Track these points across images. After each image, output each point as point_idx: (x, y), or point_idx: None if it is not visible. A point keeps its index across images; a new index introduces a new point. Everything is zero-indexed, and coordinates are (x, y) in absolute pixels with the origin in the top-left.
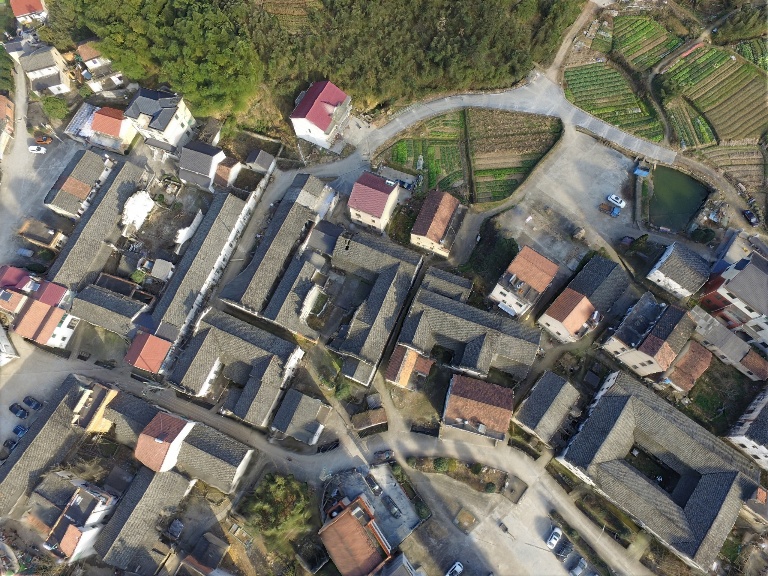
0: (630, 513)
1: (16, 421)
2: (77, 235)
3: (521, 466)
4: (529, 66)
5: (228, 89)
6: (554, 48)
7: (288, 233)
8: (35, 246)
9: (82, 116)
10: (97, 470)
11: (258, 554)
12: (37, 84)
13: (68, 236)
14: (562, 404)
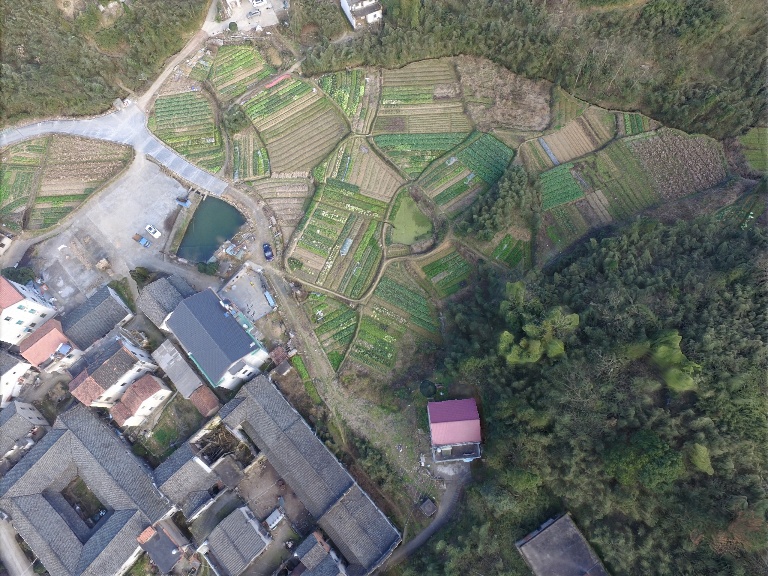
0: None
1: None
2: None
3: None
4: (106, 94)
5: None
6: (151, 76)
7: None
8: None
9: None
10: None
11: None
12: None
13: None
14: (7, 436)
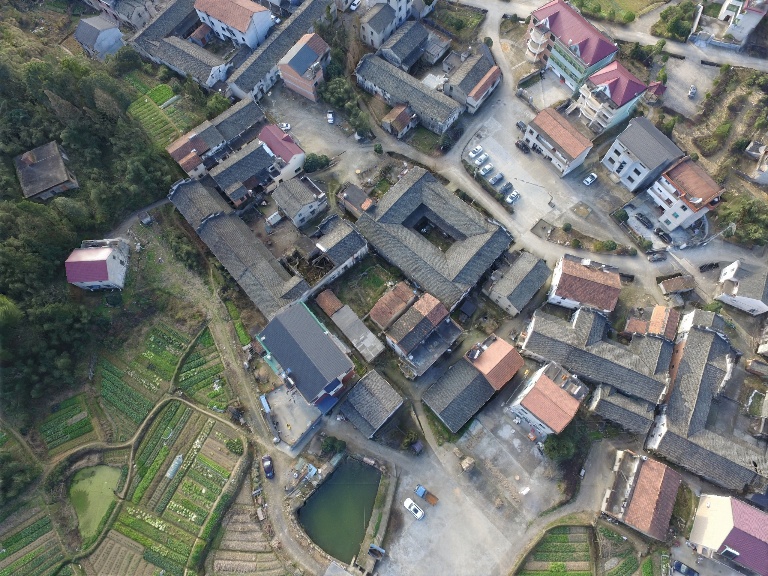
0: None
1: None
2: None
3: (536, 245)
4: None
5: None
6: None
7: None
8: None
9: None
10: None
11: None
12: None
13: None
14: (511, 280)
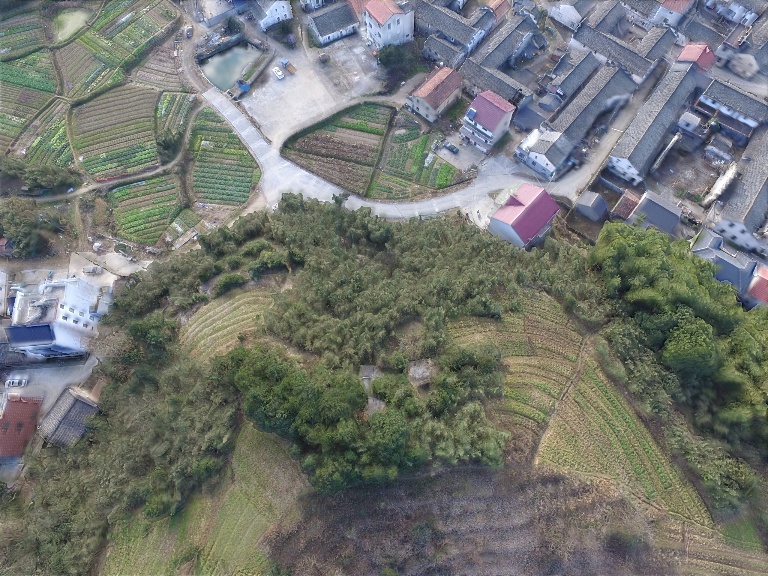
0: None
1: None
2: None
3: None
4: None
5: None
6: None
7: (572, 113)
8: None
9: None
10: None
11: None
12: None
13: None
14: None
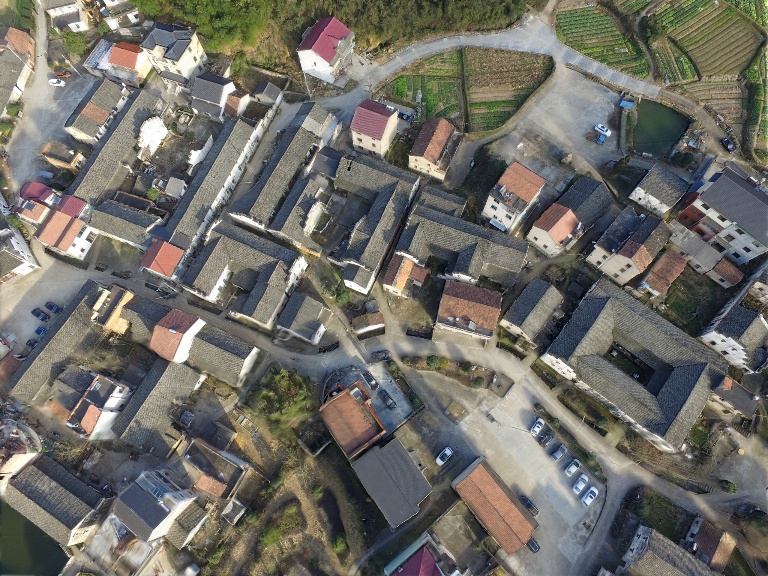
0: (607, 401)
1: (38, 324)
2: (96, 155)
3: (508, 365)
4: (523, 7)
5: (239, 21)
6: None
7: (294, 155)
8: (55, 169)
9: (100, 51)
10: (115, 361)
11: (263, 441)
12: (57, 21)
13: (87, 158)
14: (547, 305)
